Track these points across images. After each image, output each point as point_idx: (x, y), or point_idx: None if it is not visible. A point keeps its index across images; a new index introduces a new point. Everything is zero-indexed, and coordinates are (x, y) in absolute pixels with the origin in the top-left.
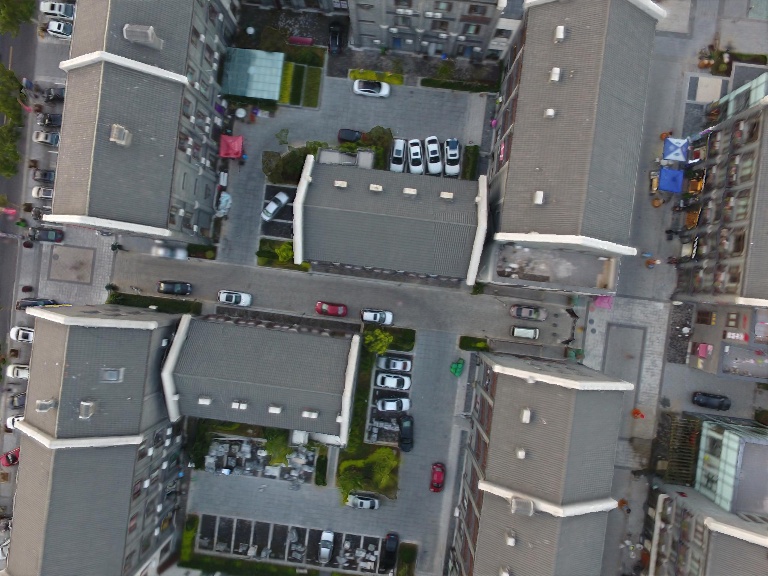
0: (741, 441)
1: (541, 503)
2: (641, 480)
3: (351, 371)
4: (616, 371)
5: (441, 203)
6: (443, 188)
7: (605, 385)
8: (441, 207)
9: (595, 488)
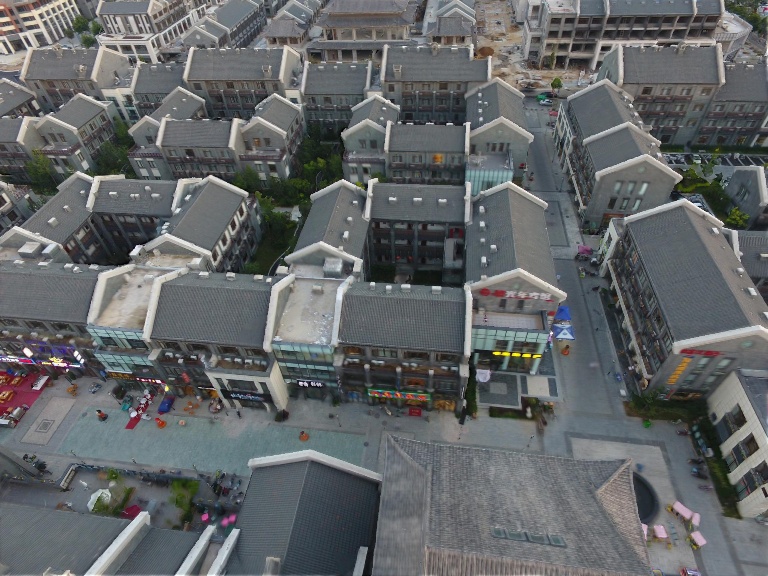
0: (513, 170)
1: (638, 128)
2: (524, 187)
3: (763, 181)
4: (555, 226)
5: (766, 252)
6: (767, 267)
7: (623, 164)
8: (765, 249)
9: (602, 141)
